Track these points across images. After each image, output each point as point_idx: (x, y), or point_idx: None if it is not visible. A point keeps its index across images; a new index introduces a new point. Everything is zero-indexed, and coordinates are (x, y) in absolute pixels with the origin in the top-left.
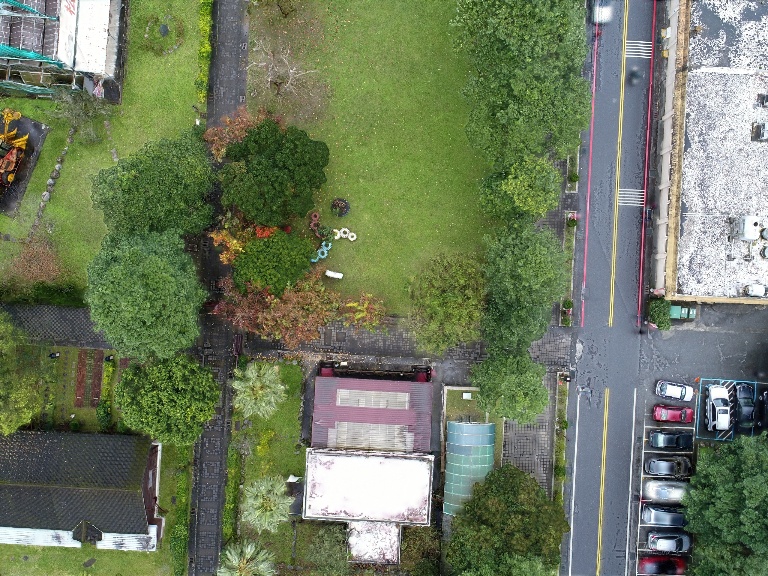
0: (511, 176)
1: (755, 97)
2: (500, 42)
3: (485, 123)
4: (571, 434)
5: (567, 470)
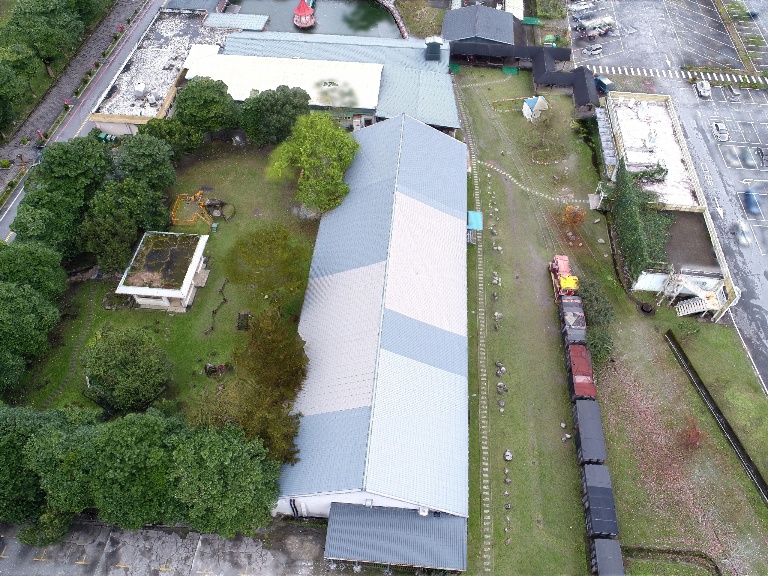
0: (2, 48)
1: (170, 57)
2: (21, 10)
3: (4, 37)
4: (16, 193)
5: (3, 209)
